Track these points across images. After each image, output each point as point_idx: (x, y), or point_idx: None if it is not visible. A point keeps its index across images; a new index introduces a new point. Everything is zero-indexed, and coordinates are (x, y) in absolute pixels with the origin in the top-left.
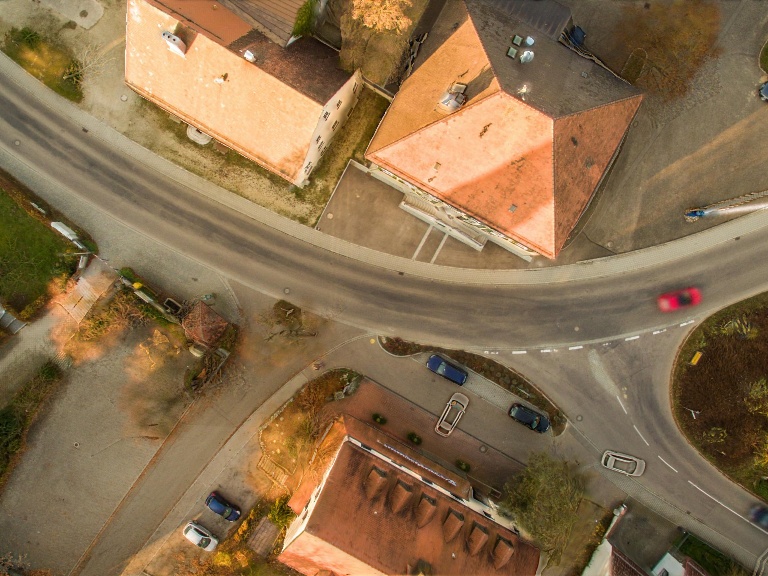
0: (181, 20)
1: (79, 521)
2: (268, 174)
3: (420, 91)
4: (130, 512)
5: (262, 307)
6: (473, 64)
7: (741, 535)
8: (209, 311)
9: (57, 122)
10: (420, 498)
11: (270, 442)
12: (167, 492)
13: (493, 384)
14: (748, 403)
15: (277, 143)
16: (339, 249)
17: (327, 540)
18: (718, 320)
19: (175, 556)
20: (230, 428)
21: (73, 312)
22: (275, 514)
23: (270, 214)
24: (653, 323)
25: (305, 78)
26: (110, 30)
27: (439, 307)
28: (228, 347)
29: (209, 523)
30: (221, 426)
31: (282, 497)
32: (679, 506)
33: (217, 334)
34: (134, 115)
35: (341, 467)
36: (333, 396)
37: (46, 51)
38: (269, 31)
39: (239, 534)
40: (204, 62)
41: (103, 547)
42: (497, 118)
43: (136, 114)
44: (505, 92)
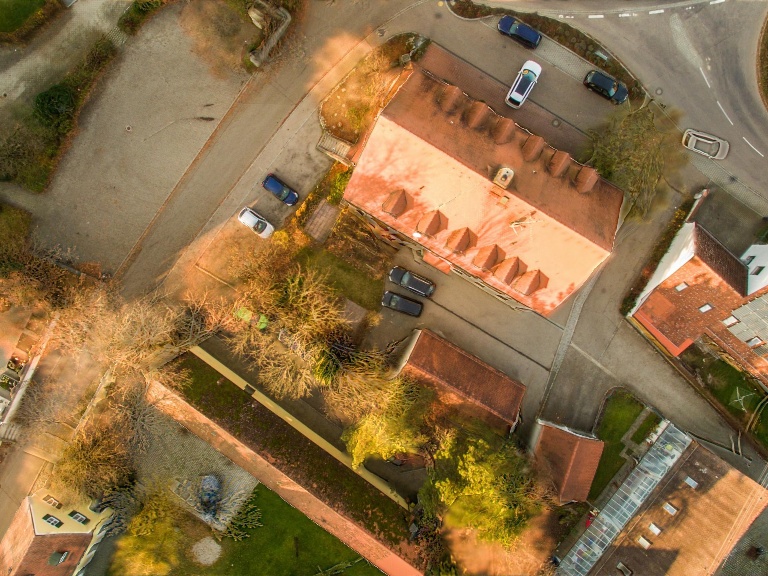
0: None
1: (130, 210)
2: None
3: None
4: (183, 200)
5: None
6: None
7: None
8: None
9: None
10: None
11: (331, 116)
12: (222, 178)
13: (567, 51)
14: None
15: None
16: None
17: (403, 127)
18: None
19: (229, 247)
20: (289, 106)
21: None
22: None
23: None
24: None
25: None
26: None
27: None
28: (289, 8)
29: (265, 211)
30: (279, 104)
31: (343, 172)
32: (764, 195)
33: None
34: None
35: (414, 83)
36: (398, 61)
37: None
38: None
39: (297, 216)
40: None
41: (154, 238)
42: None
43: None
44: None
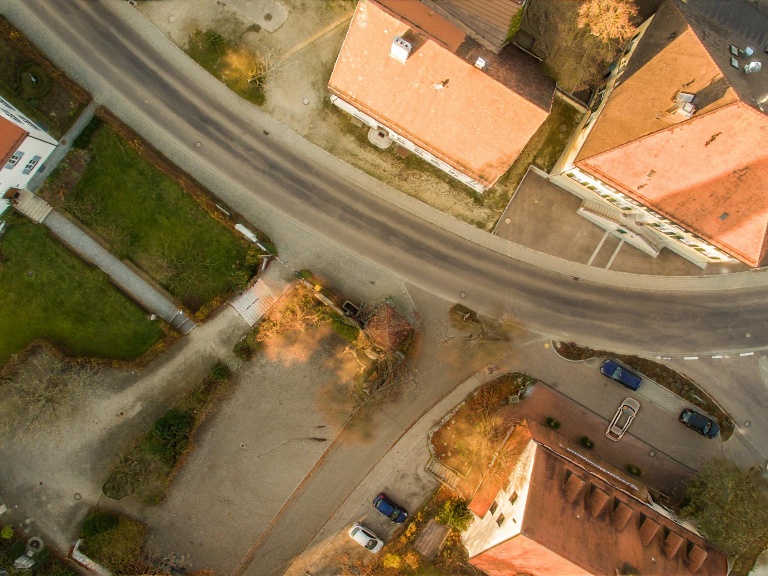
0: (412, 26)
1: (243, 522)
2: (447, 179)
3: (636, 99)
4: (295, 513)
5: (438, 311)
6: (700, 74)
7: None
8: (394, 314)
9: (238, 124)
10: (614, 502)
11: (441, 445)
12: (332, 494)
13: (664, 389)
14: None
15: (483, 149)
16: (515, 254)
17: (542, 543)
18: None
19: (338, 557)
20: (399, 430)
21: (246, 314)
22: (449, 516)
23: (448, 218)
24: None
25: (524, 85)
26: (294, 34)
27: (613, 312)
28: (404, 350)
29: (374, 525)
30: (390, 428)
31: (453, 500)
32: None
33: (401, 337)
34: (315, 118)
35: (540, 471)
36: (507, 400)
37: (230, 54)
38: (482, 38)
39: (407, 536)
40: (426, 68)
41: (266, 548)
42: (729, 127)
43: (317, 117)
44: (744, 102)
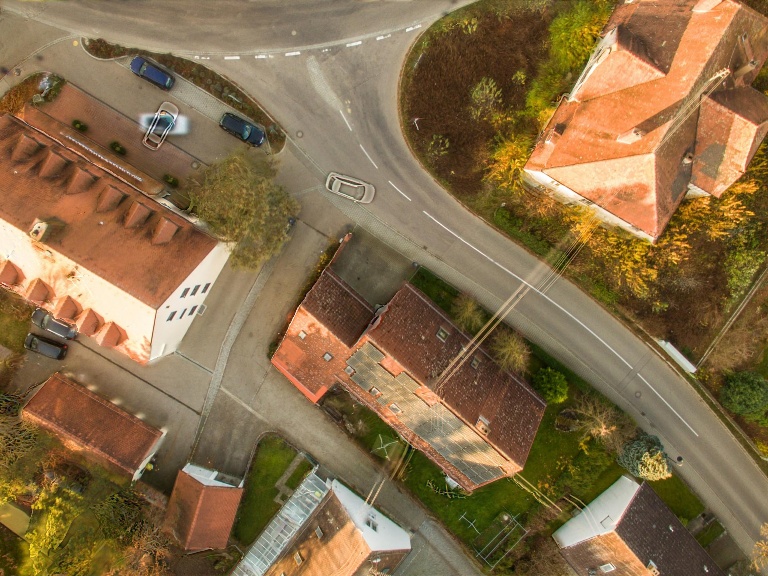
0: None
1: None
2: None
3: None
4: None
5: None
6: None
7: (485, 276)
8: None
9: None
10: None
11: None
12: None
13: (204, 93)
14: (471, 108)
15: None
16: None
17: None
18: (445, 23)
19: None
20: None
21: None
22: None
23: None
24: (376, 27)
25: None
26: None
27: (146, 8)
28: None
29: None
30: None
31: None
32: (414, 240)
33: None
34: None
35: None
36: (32, 101)
37: None
38: None
39: None
40: None
41: None
42: None
43: None
44: None
